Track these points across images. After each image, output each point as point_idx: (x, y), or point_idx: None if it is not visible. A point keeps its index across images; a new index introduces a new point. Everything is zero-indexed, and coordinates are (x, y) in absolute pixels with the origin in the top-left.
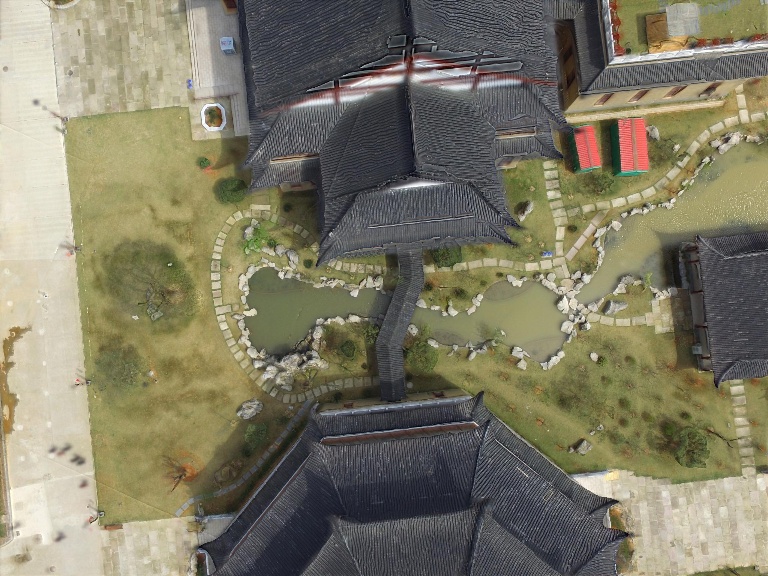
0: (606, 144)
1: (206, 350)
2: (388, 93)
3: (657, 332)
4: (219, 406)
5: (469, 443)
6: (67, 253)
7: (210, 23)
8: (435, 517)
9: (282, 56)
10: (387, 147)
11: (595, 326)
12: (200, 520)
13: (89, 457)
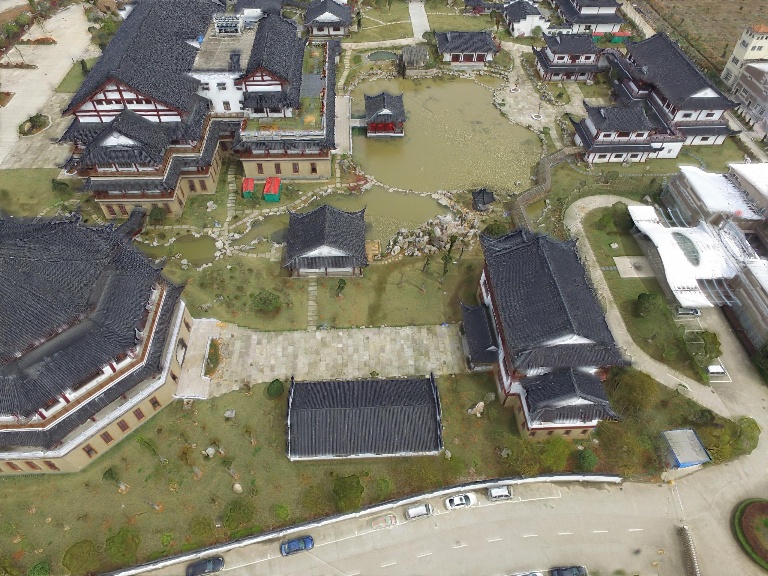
0: None
1: None
2: None
3: (271, 260)
4: None
5: None
6: None
7: None
8: None
9: None
10: None
11: (235, 256)
12: None
13: None
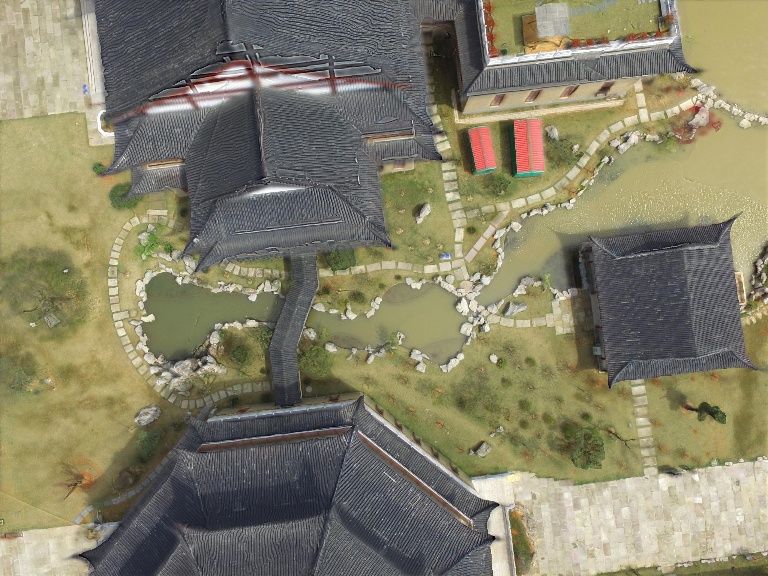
0: (505, 145)
1: (104, 356)
2: (241, 98)
3: (558, 333)
4: (117, 412)
5: (336, 448)
6: None
7: None
8: (282, 524)
9: (129, 62)
10: (244, 152)
11: (495, 328)
12: None
13: None
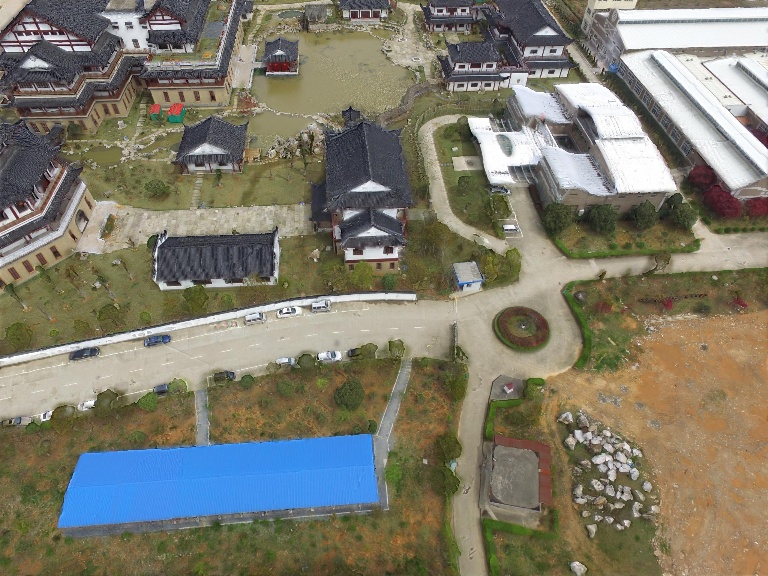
0: None
1: None
2: None
3: (168, 163)
4: None
5: None
6: None
7: None
8: None
9: None
10: None
11: (138, 160)
12: None
13: None
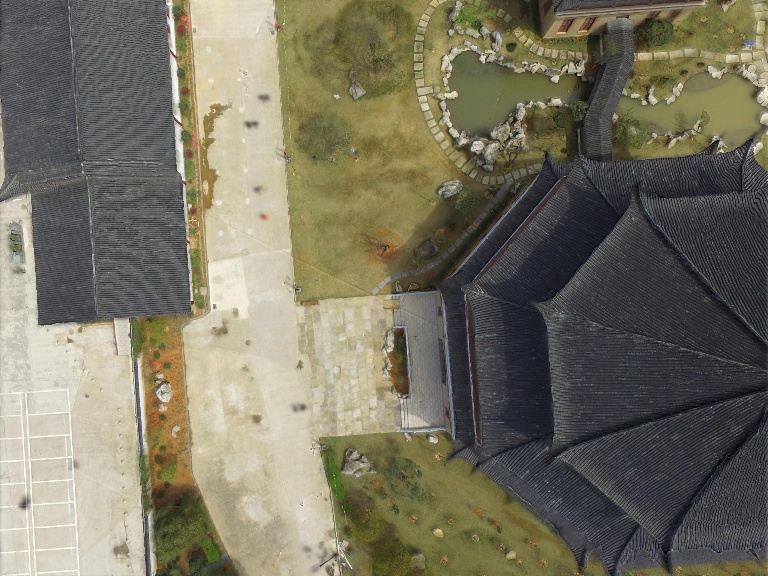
0: None
1: (406, 131)
2: None
3: None
4: (418, 186)
5: (730, 162)
6: (268, 33)
7: None
8: (733, 192)
9: None
10: None
11: None
12: (398, 296)
13: (286, 234)
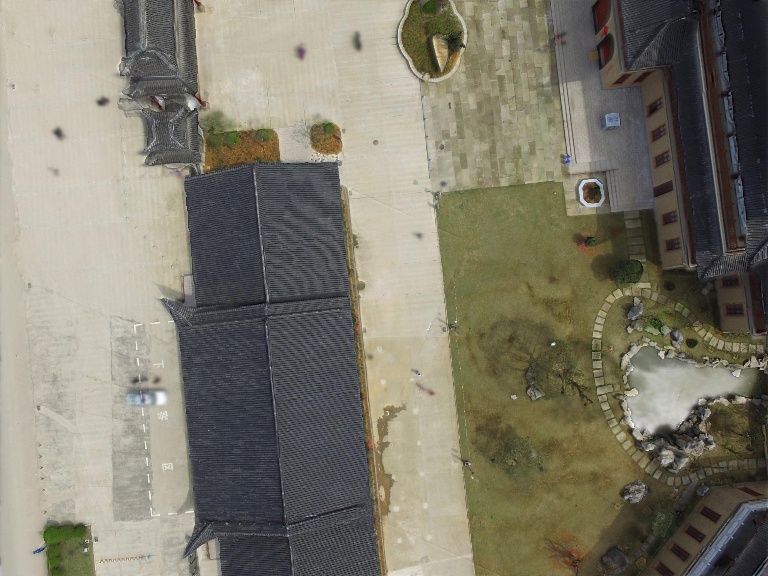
0: None
1: (587, 431)
2: None
3: None
4: (601, 488)
5: None
6: (440, 330)
7: (586, 97)
8: None
9: None
10: None
11: None
12: None
13: (466, 539)
